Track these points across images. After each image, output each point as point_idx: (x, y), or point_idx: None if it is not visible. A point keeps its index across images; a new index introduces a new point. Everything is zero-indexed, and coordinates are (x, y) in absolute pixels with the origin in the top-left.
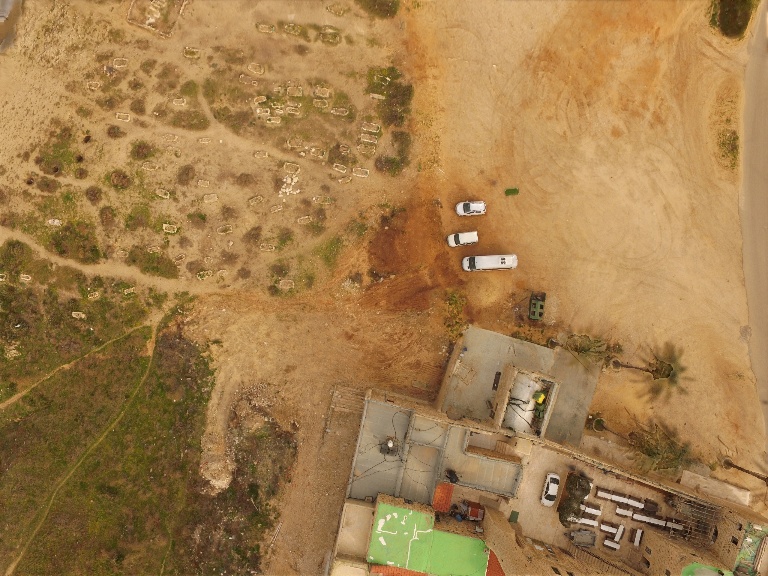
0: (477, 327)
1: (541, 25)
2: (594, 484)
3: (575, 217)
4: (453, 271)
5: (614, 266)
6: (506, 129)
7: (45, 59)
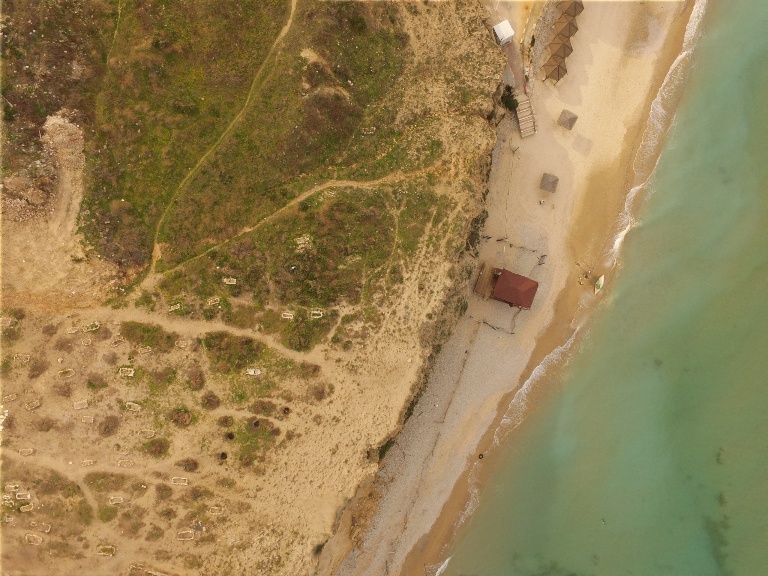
0: None
1: None
2: None
3: None
4: None
5: None
6: None
7: (277, 533)
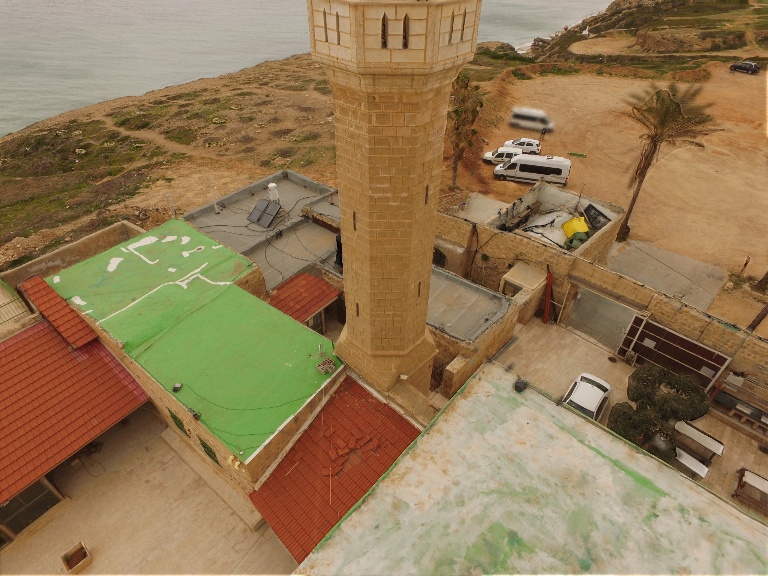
0: (491, 198)
1: (627, 104)
2: (728, 463)
3: (663, 182)
4: (480, 175)
5: (733, 223)
6: (579, 130)
7: None
